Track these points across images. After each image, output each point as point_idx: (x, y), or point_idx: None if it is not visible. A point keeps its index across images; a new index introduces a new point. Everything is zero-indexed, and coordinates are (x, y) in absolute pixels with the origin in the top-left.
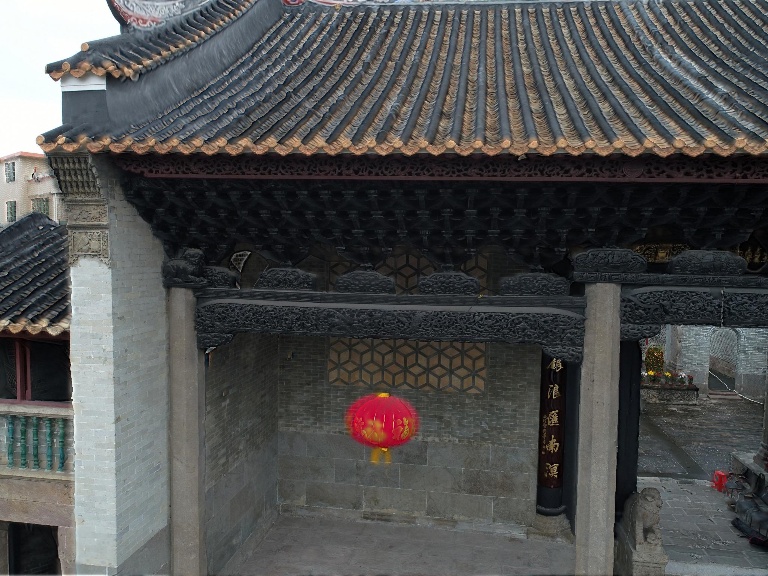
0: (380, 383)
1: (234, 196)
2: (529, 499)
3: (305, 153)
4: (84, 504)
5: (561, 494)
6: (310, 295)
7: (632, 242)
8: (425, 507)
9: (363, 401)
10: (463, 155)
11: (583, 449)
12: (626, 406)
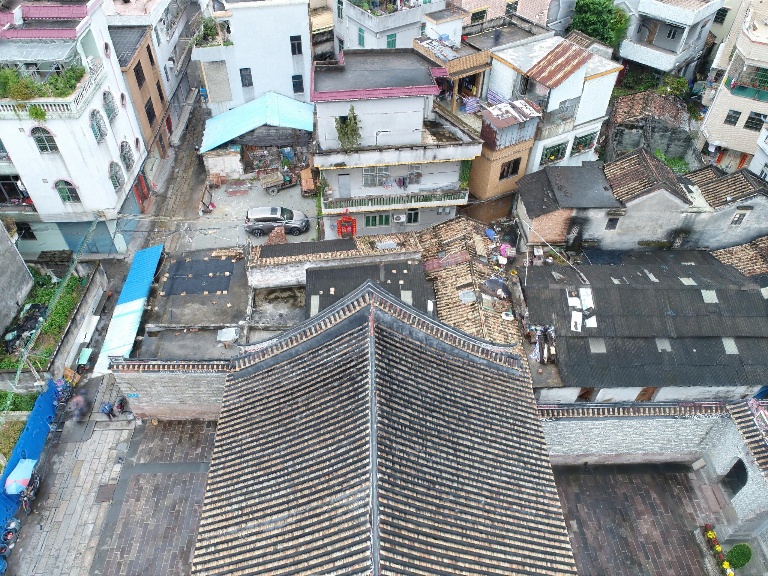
0: None
1: None
2: None
3: None
4: None
5: None
6: None
7: None
8: None
9: None
10: None
11: None
12: None
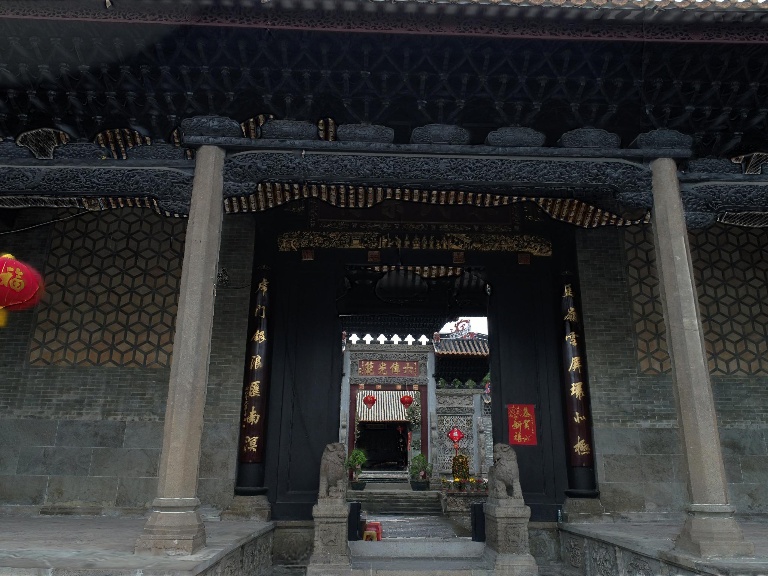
0: (84, 361)
1: None
2: (227, 478)
3: None
4: None
5: (262, 472)
6: None
7: (227, 109)
8: (115, 496)
9: (63, 381)
10: None
11: (182, 286)
12: (328, 380)
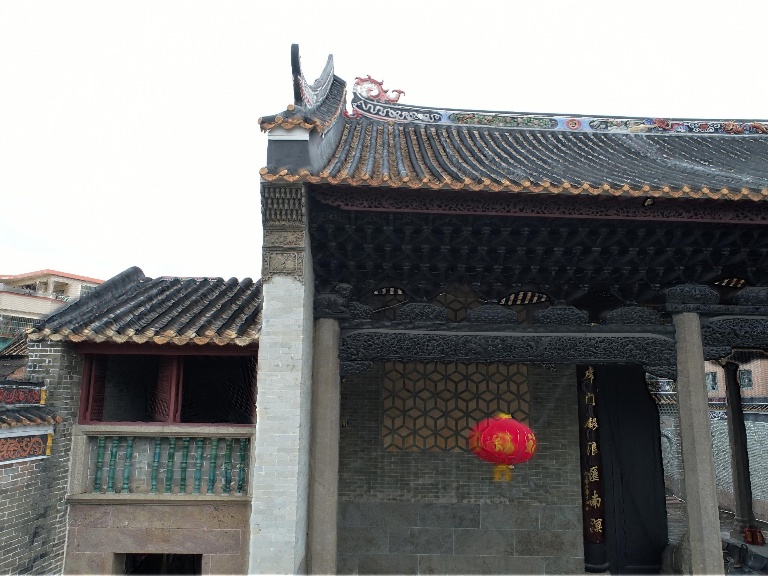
0: (433, 447)
1: (409, 230)
2: (577, 557)
3: (493, 190)
4: (262, 512)
5: (605, 550)
6: (448, 325)
7: None
8: (480, 573)
9: (417, 466)
10: (616, 195)
11: (687, 452)
12: (651, 462)
